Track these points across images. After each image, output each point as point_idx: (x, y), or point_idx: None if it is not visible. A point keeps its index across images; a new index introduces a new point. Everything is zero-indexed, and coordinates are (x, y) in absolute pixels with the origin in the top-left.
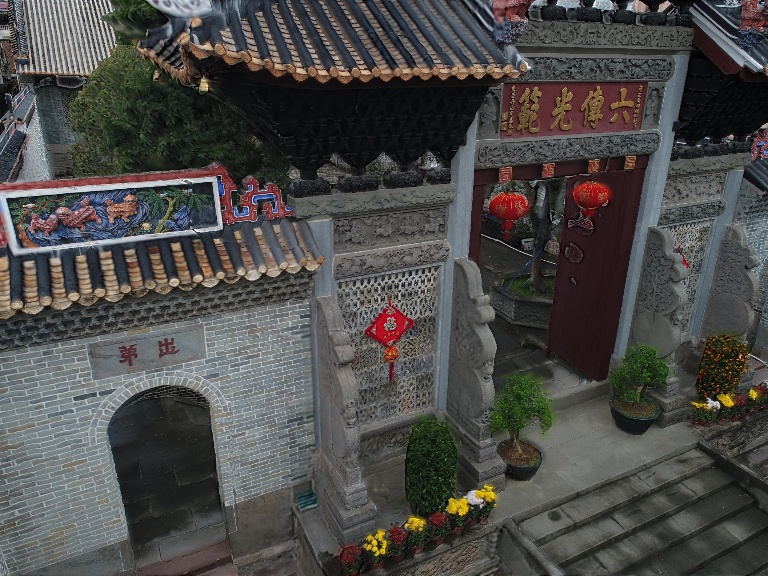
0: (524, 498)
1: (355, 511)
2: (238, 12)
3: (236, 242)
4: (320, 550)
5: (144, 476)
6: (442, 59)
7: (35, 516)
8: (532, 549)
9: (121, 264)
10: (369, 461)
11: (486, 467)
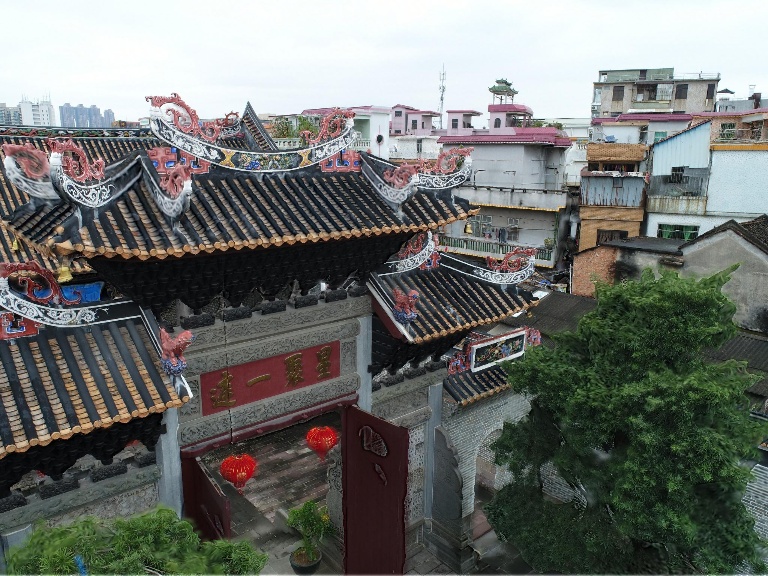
0: None
1: None
2: None
3: None
4: None
5: (565, 574)
6: None
7: None
8: None
9: None
10: None
11: None
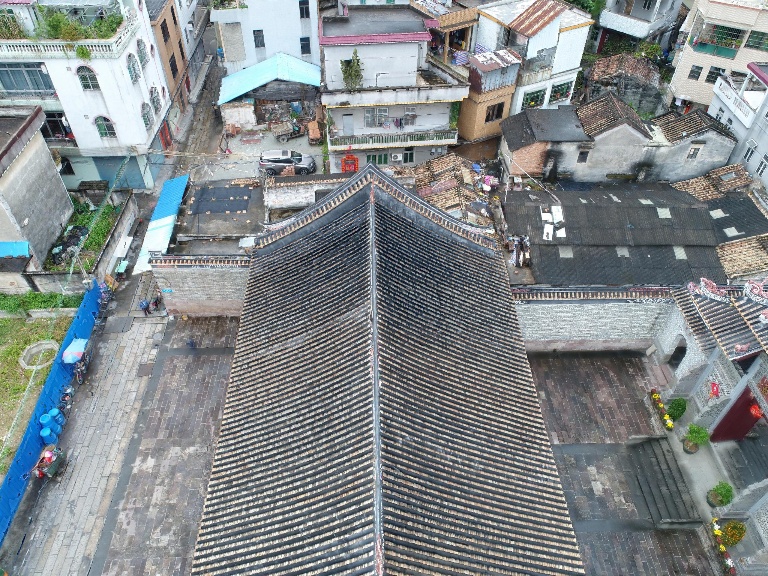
0: (675, 445)
1: (667, 394)
2: (708, 298)
3: (706, 333)
4: (661, 392)
5: None
6: (723, 339)
7: (664, 333)
8: (655, 436)
9: (693, 314)
10: (693, 410)
11: (682, 430)
